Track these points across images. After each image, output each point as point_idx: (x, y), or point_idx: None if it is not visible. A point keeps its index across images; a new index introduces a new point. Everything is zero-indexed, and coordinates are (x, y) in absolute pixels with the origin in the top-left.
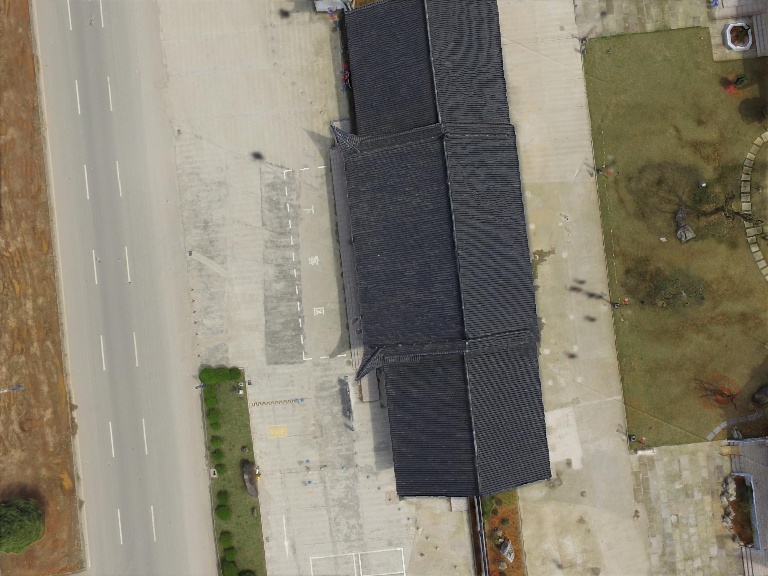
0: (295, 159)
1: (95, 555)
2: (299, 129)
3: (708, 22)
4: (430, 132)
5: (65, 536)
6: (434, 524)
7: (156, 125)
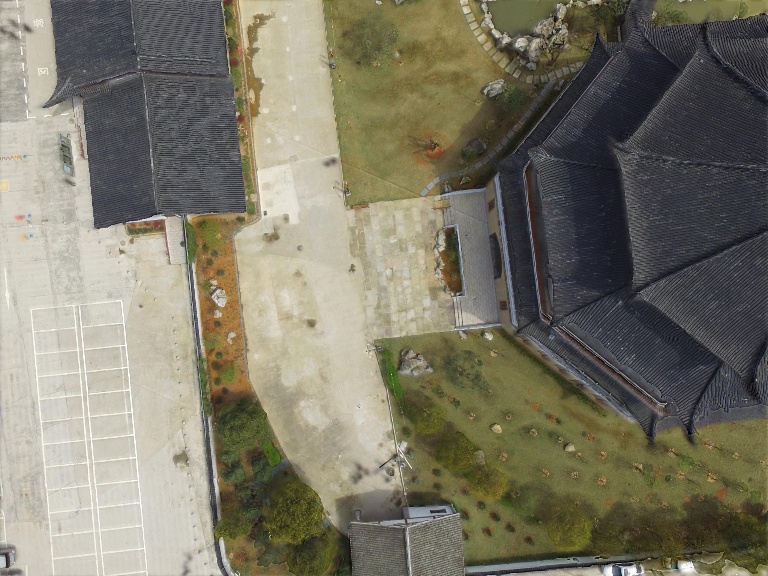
0: None
1: None
2: None
3: None
4: None
5: None
6: (153, 277)
7: None
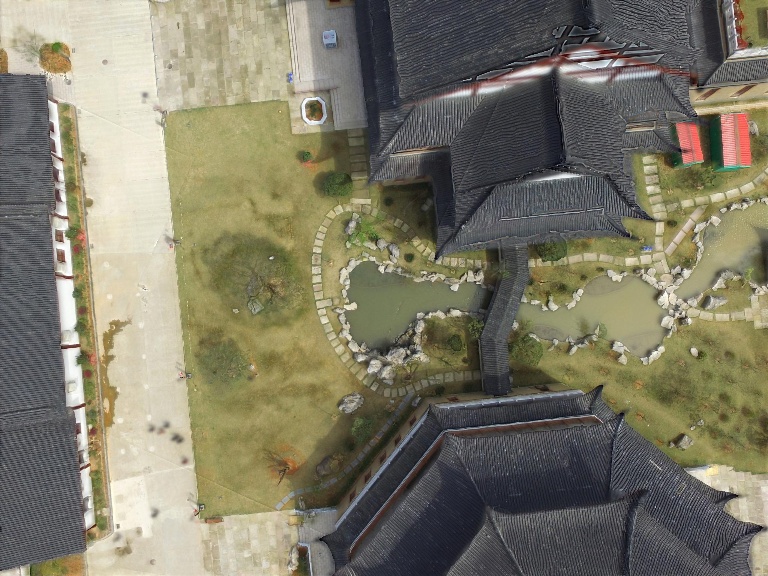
0: None
1: None
2: None
3: (288, 95)
4: None
5: None
6: None
7: None
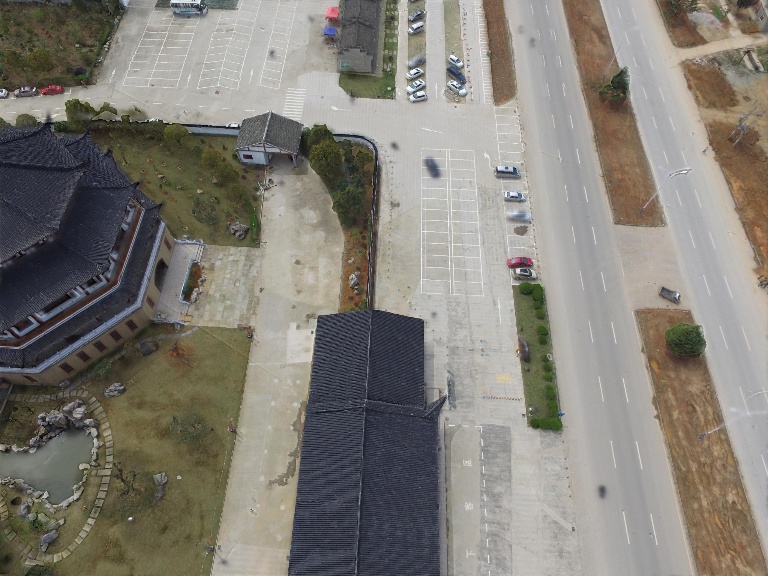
0: None
1: (630, 318)
2: None
3: None
4: None
5: (652, 332)
6: (398, 304)
7: None
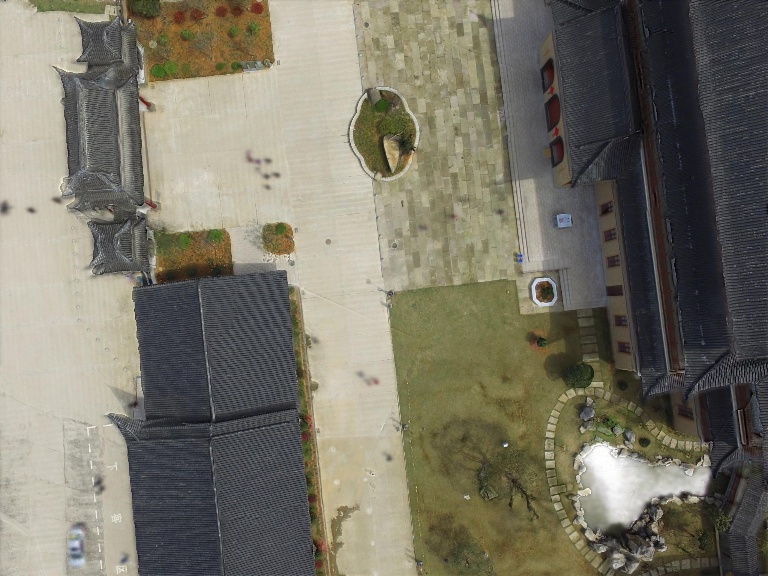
0: (98, 415)
1: None
2: (103, 385)
3: (515, 275)
4: (200, 432)
5: None
6: None
7: None
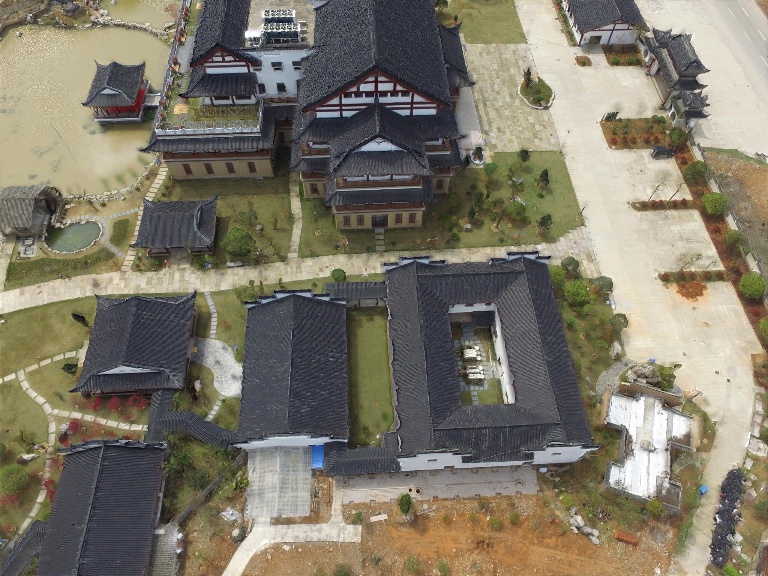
0: (654, 15)
1: None
2: None
3: (466, 45)
4: None
5: None
6: None
7: (722, 27)
